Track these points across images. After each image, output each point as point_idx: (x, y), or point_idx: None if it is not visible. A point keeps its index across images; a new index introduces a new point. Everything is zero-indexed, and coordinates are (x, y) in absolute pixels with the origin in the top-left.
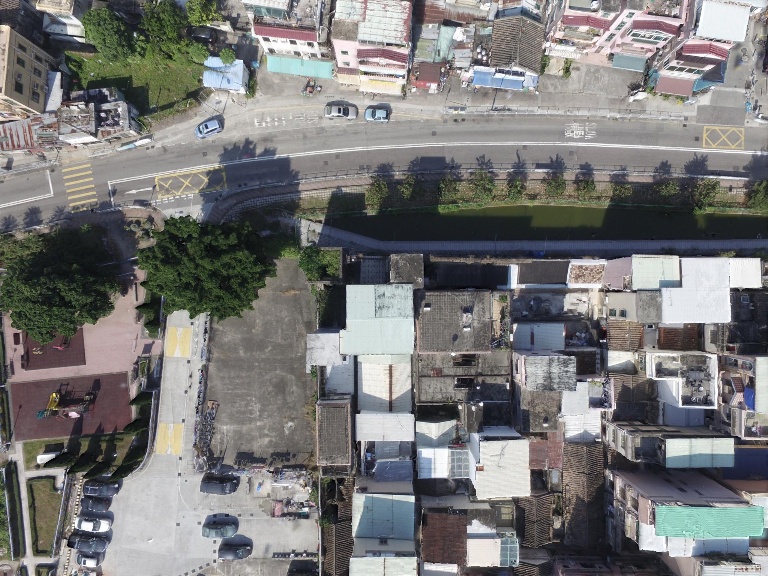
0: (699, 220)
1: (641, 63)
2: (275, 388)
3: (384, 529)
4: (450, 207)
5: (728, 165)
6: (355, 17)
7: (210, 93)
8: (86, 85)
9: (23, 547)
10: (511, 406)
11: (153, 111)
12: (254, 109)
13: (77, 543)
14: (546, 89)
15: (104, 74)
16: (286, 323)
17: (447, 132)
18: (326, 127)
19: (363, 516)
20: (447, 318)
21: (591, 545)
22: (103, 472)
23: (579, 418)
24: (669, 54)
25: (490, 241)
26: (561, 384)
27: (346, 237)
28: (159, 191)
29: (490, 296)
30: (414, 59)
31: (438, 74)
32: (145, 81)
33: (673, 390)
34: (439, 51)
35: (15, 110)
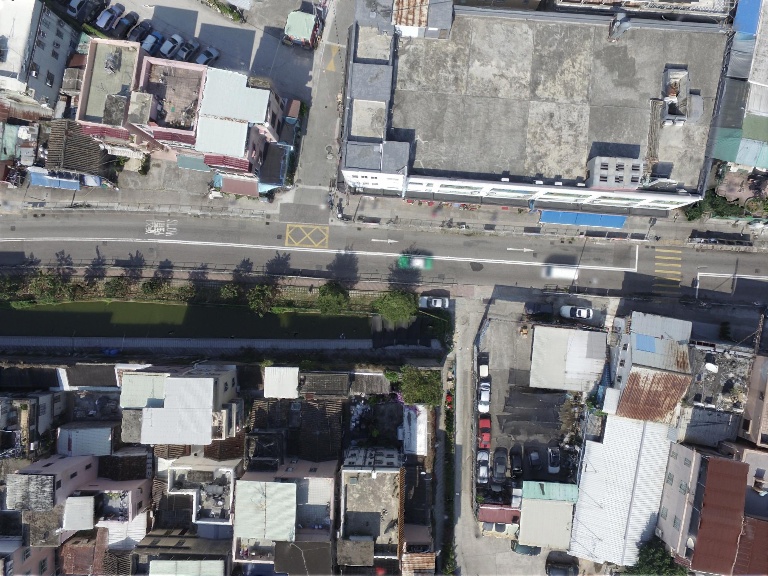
0: (282, 319)
1: (205, 164)
2: None
3: None
4: (23, 303)
5: (311, 264)
6: None
7: None
8: None
9: None
10: None
11: None
12: None
13: None
14: (126, 185)
15: None
16: None
17: (26, 227)
18: None
19: None
20: None
21: None
22: None
23: (122, 525)
24: None
25: (67, 337)
26: (38, 504)
27: None
28: None
29: None
30: None
31: (2, 172)
32: None
33: None
34: (5, 149)
35: None
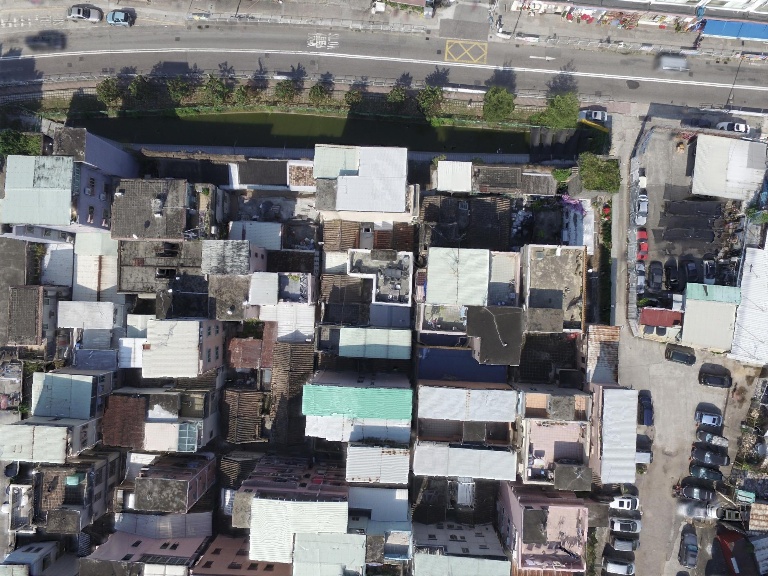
0: (439, 133)
1: None
2: (8, 283)
3: (62, 408)
4: (188, 111)
5: (469, 79)
6: None
7: None
8: None
9: None
10: None
11: None
12: (1, 10)
13: None
14: None
15: None
16: None
17: (190, 38)
18: (71, 29)
19: (42, 395)
20: (140, 205)
21: (293, 443)
22: None
23: (291, 318)
24: None
25: (229, 147)
26: (234, 267)
27: None
28: None
29: (185, 185)
30: None
31: None
32: None
33: None
34: None
35: None
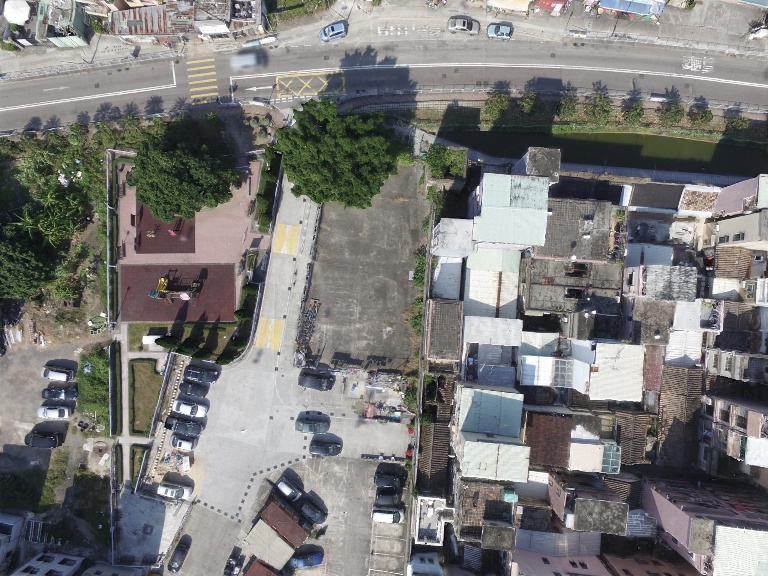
0: None
1: None
2: (377, 292)
3: (491, 425)
4: (564, 128)
5: None
6: None
7: None
8: None
9: (120, 425)
10: (619, 320)
11: (280, 11)
12: (378, 17)
13: (175, 424)
14: (667, 20)
15: None
16: (393, 229)
17: (566, 55)
18: (447, 41)
19: (471, 410)
20: (567, 225)
21: (684, 467)
22: (206, 357)
23: (681, 342)
24: None
25: (599, 166)
26: (681, 294)
27: None
28: (279, 90)
29: (611, 207)
30: None
31: None
32: None
33: None
34: None
35: None
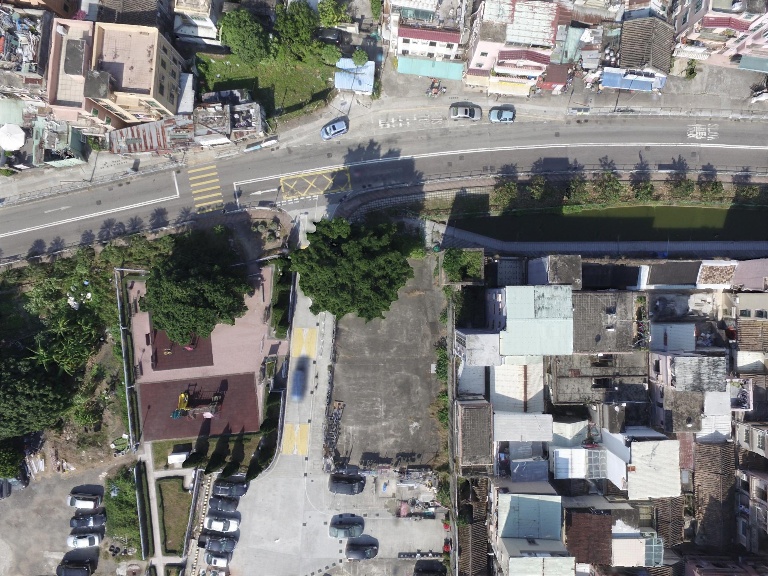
0: None
1: None
2: (400, 388)
3: (530, 529)
4: (574, 208)
5: None
6: (503, 19)
7: (336, 94)
8: (212, 86)
9: (152, 547)
10: (649, 406)
11: (279, 112)
12: (379, 110)
13: (208, 543)
14: (669, 90)
15: (230, 75)
16: (411, 324)
17: (570, 133)
18: (450, 128)
19: (509, 516)
20: (590, 319)
21: (725, 545)
22: (234, 472)
23: (710, 418)
24: None
25: (613, 242)
26: (711, 385)
27: (470, 238)
28: (284, 192)
29: (632, 297)
30: None
31: (566, 75)
32: (271, 82)
33: None
34: (566, 52)
35: (152, 112)
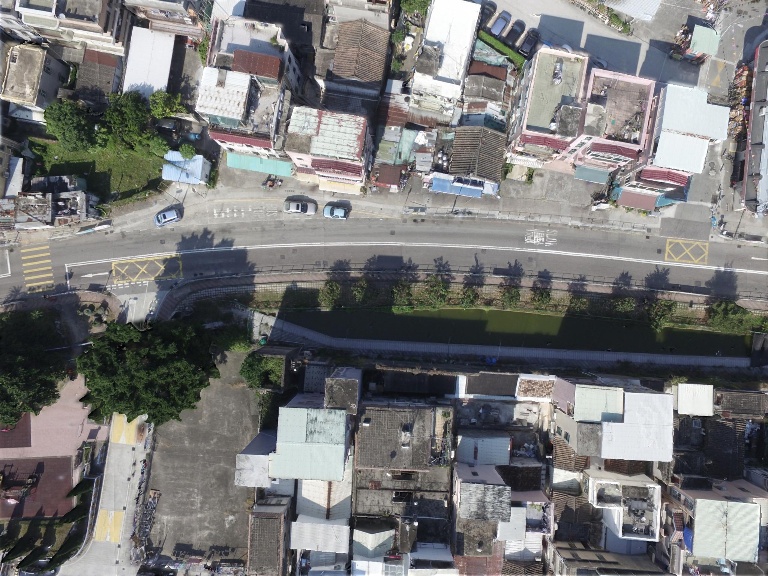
0: (658, 334)
1: (603, 176)
2: (218, 480)
3: None
4: (404, 308)
5: (690, 280)
6: (308, 131)
7: (171, 182)
8: (49, 168)
9: None
10: (448, 524)
11: (114, 197)
12: (214, 200)
13: None
14: (508, 194)
15: (68, 158)
16: (233, 416)
17: (406, 232)
18: (285, 221)
19: None
20: (386, 434)
21: None
22: (39, 558)
23: None
24: (630, 173)
25: (443, 344)
26: (495, 514)
27: (298, 332)
28: (115, 276)
29: (431, 414)
30: (375, 160)
31: (398, 177)
32: (108, 167)
33: (615, 518)
34: (400, 154)
35: None
